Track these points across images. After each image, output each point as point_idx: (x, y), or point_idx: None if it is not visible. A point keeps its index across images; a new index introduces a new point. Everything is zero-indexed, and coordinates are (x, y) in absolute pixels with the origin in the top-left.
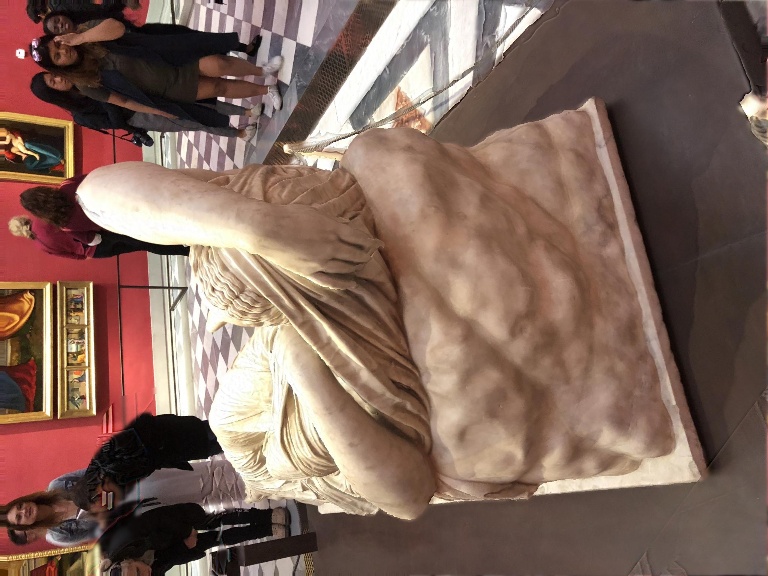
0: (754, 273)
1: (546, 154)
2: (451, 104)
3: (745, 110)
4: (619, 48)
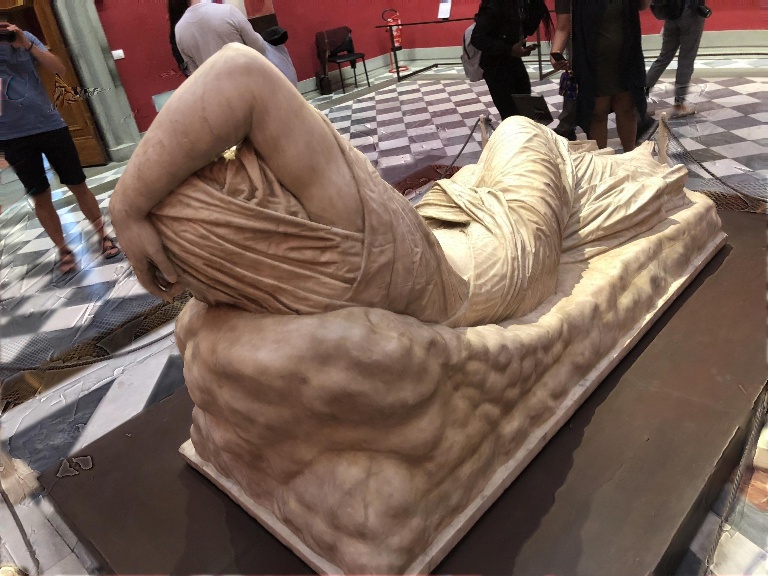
0: (187, 574)
1: (328, 516)
2: (755, 551)
3: (9, 569)
4: None
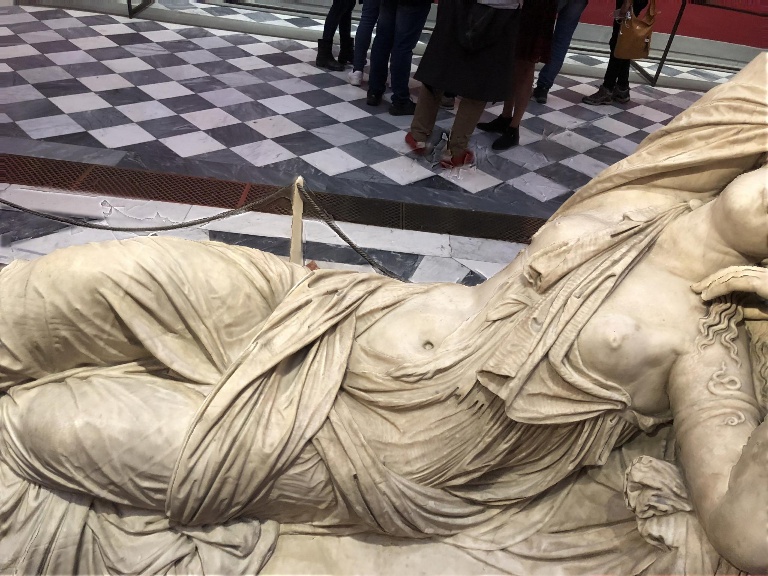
0: None
1: None
2: None
3: None
4: None
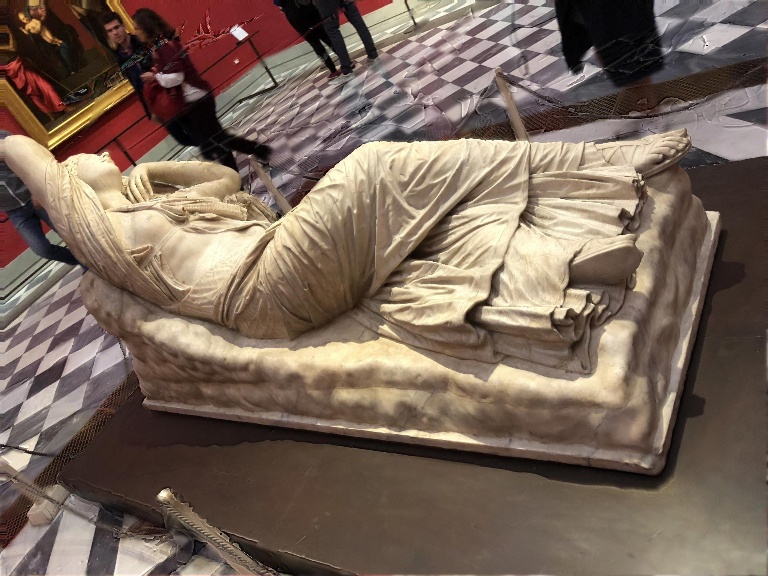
0: None
1: None
2: None
3: None
4: (127, 433)
